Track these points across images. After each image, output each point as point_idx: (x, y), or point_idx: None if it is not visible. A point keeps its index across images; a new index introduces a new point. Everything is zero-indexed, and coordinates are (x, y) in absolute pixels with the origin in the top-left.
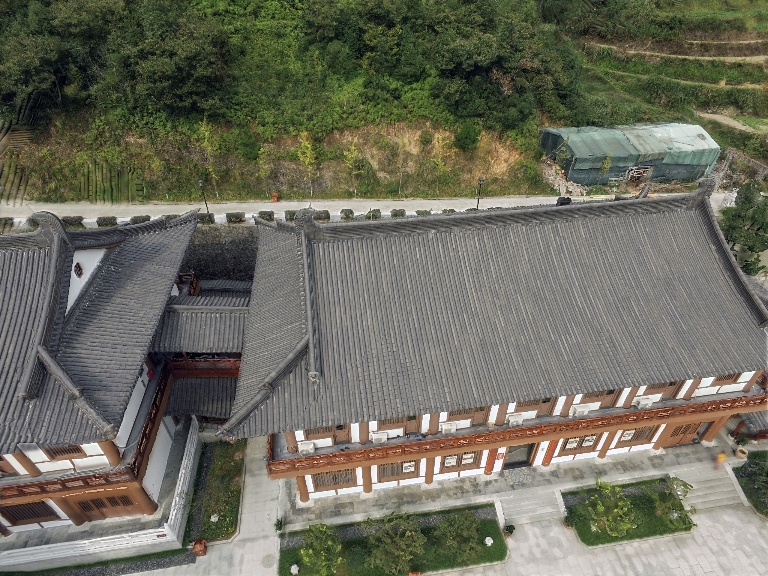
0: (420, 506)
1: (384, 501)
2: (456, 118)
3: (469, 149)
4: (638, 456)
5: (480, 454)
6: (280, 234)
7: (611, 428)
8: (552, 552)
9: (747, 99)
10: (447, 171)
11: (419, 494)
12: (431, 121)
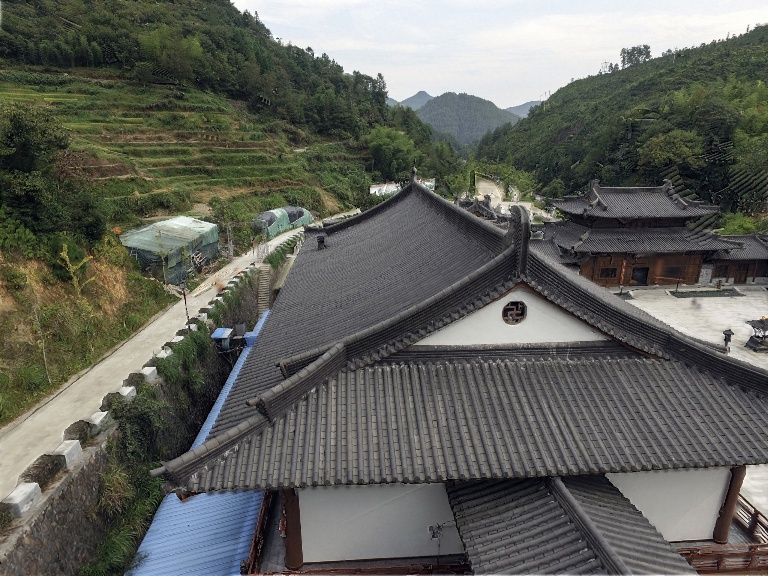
0: None
1: None
2: (39, 235)
3: (84, 274)
4: None
5: None
6: (281, 424)
7: None
8: None
9: (169, 199)
10: (90, 311)
11: None
12: (0, 250)
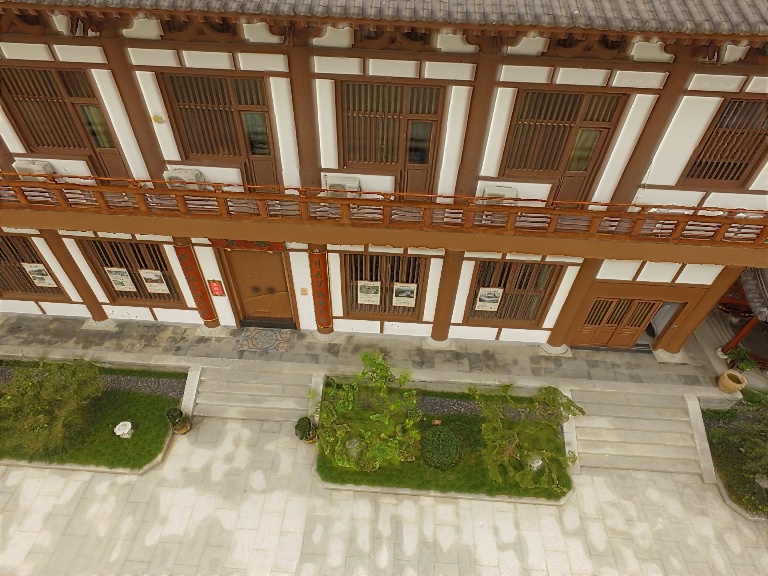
0: (55, 350)
1: (4, 332)
2: None
3: None
4: (513, 351)
5: (169, 273)
6: None
7: (401, 235)
8: (247, 477)
9: None
10: None
11: (70, 333)
12: None
